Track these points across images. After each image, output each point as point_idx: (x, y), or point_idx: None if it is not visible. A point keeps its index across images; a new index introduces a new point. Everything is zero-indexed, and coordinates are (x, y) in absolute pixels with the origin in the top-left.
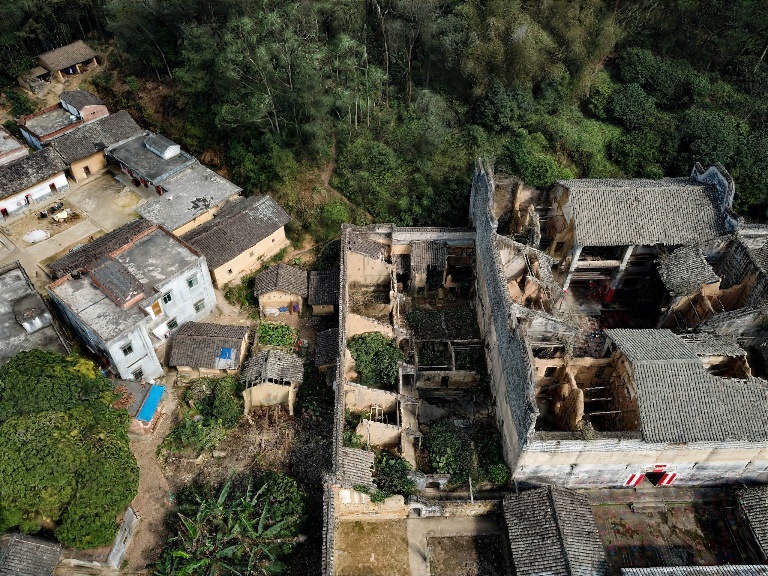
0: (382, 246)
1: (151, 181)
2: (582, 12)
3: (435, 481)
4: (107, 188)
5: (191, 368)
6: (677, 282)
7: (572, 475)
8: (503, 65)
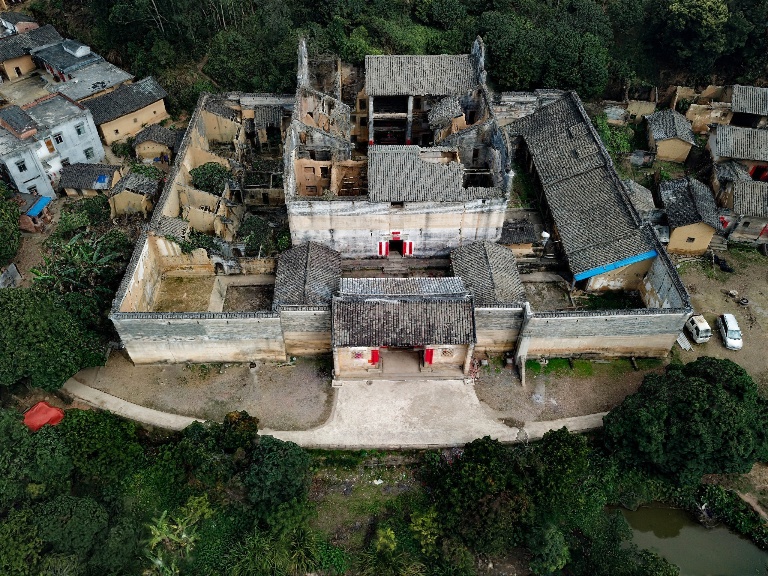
0: (235, 112)
1: (62, 70)
2: None
3: (236, 248)
4: (34, 84)
5: (77, 192)
6: (436, 119)
7: (335, 242)
8: None
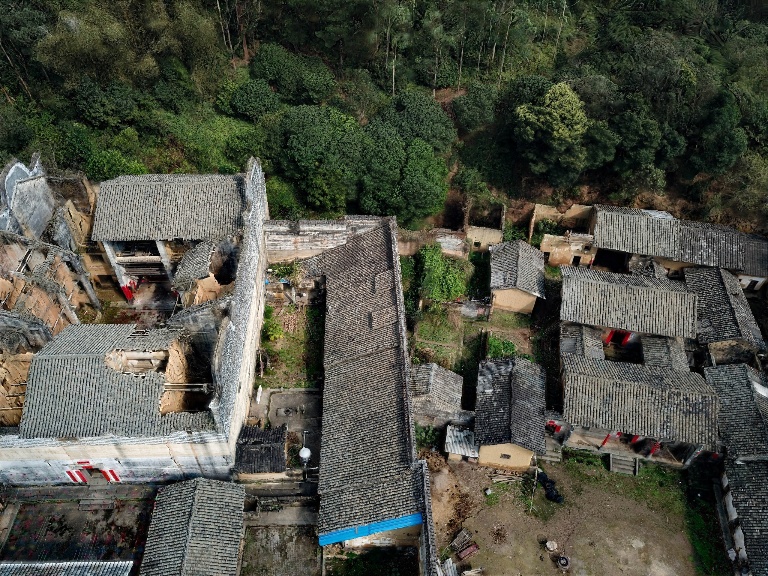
0: None
1: None
2: (176, 7)
3: None
4: None
5: None
6: (179, 277)
7: (3, 472)
8: (81, 59)
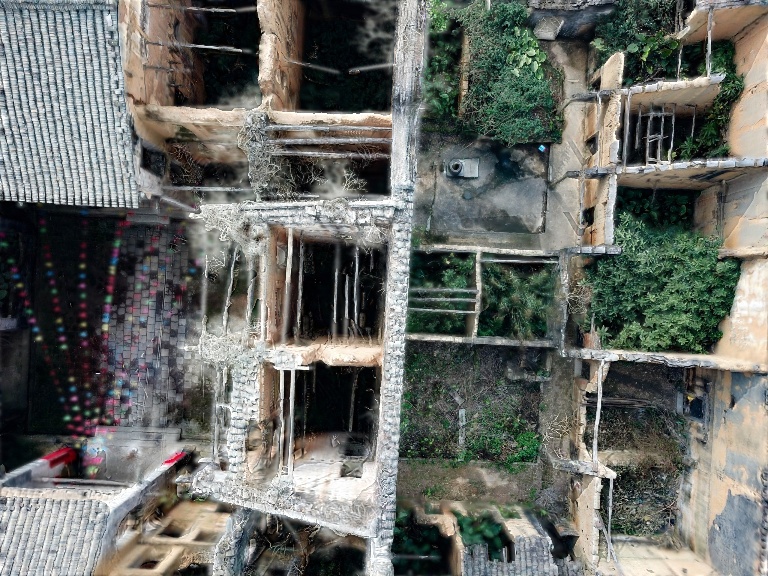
0: None
1: None
2: None
3: None
4: None
5: None
6: None
7: None
8: None
